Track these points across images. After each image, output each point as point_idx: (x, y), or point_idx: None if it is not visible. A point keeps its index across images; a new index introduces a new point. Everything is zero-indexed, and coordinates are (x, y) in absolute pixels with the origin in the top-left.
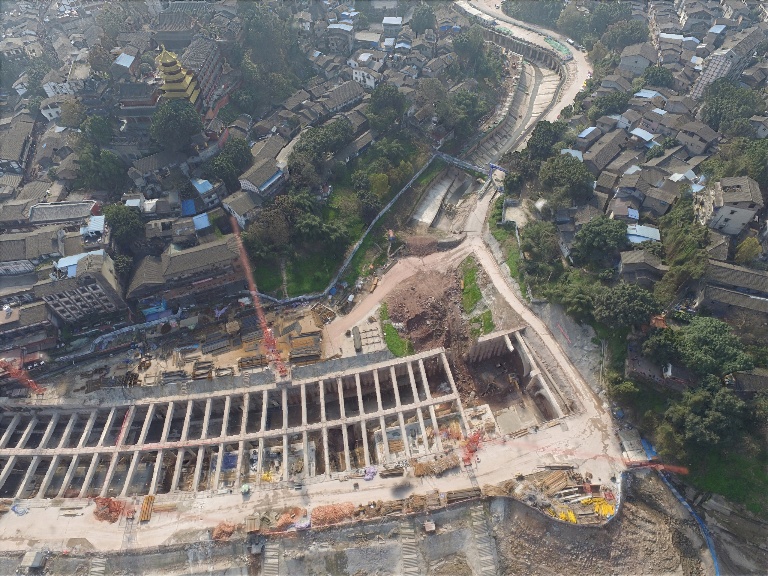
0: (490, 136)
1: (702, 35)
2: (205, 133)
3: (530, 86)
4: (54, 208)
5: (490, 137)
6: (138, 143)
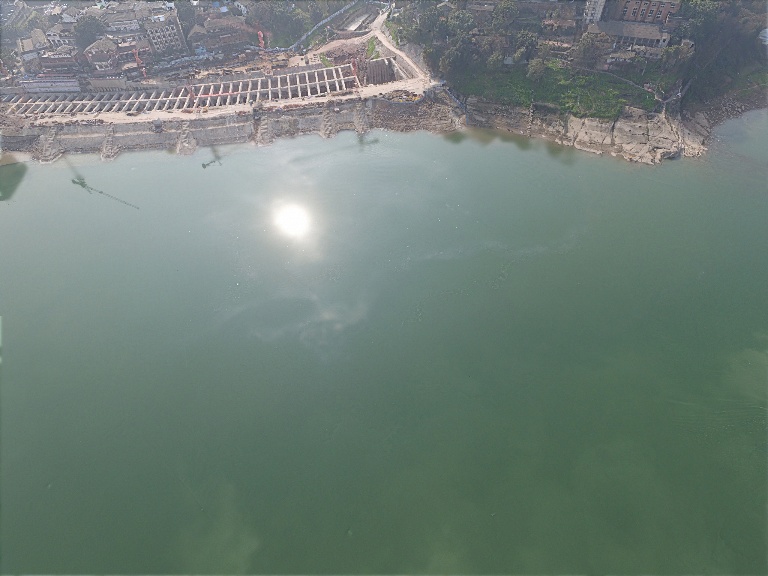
0: None
1: None
2: None
3: None
4: (145, 4)
5: None
6: None
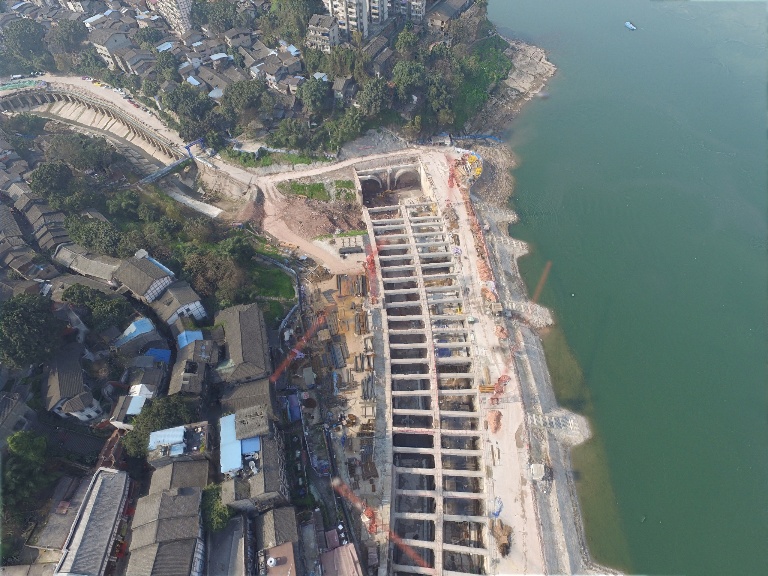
0: None
1: (104, 8)
2: None
3: None
4: (87, 533)
5: None
6: None
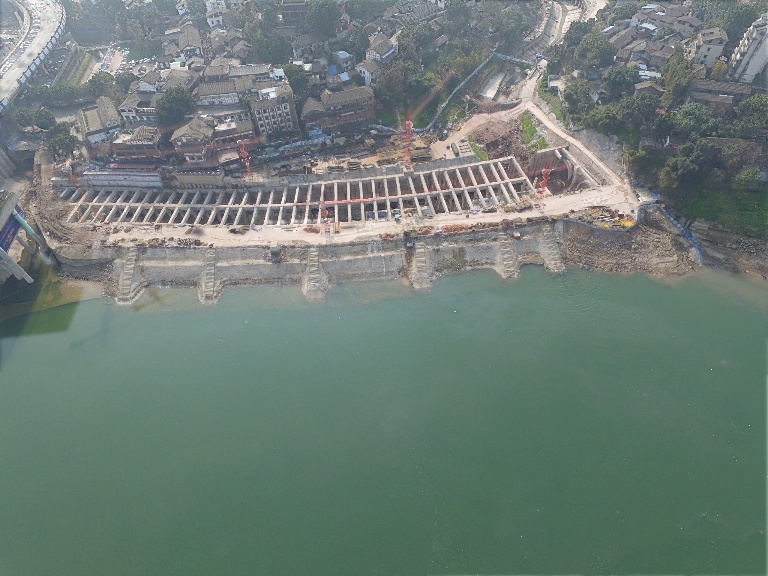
0: (531, 46)
1: None
2: (340, 22)
3: (559, 17)
4: (244, 67)
5: (531, 47)
6: (296, 27)
